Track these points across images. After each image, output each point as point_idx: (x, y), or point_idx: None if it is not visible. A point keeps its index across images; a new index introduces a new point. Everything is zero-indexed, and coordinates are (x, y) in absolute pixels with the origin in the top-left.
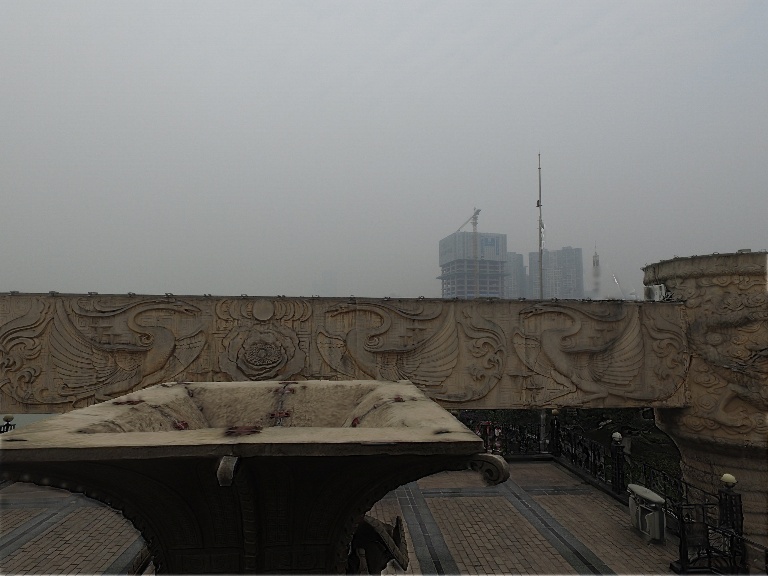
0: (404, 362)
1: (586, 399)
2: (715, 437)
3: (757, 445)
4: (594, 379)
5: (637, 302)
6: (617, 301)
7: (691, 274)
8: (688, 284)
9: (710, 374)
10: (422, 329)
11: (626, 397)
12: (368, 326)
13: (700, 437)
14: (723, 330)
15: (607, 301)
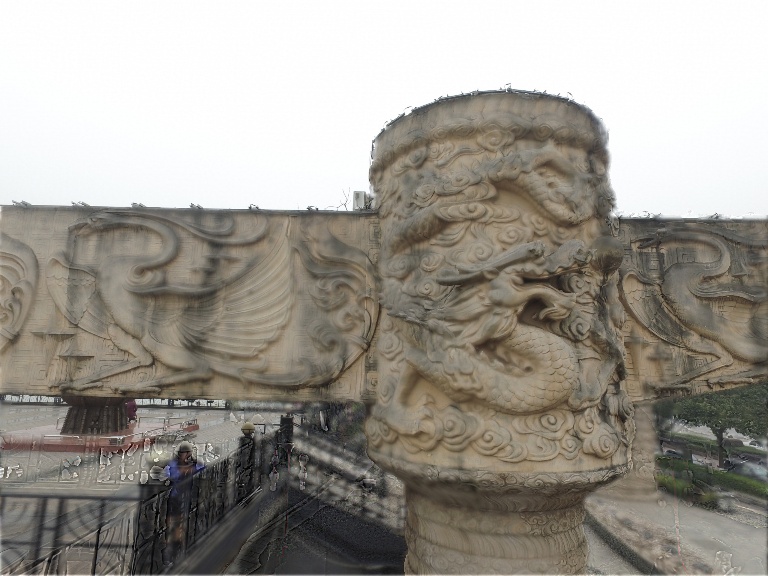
0: None
1: (164, 379)
2: (392, 458)
3: (446, 476)
4: (183, 342)
5: (288, 210)
6: None
7: (382, 158)
8: (384, 178)
9: (393, 334)
10: None
11: (242, 377)
12: None
13: (379, 458)
14: (413, 248)
15: (232, 208)
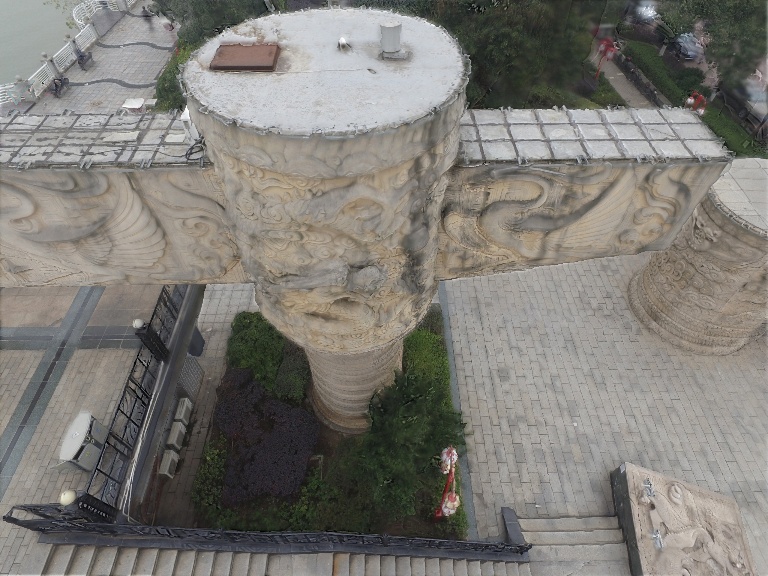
0: None
1: (97, 281)
2: None
3: None
4: (95, 264)
5: (121, 167)
6: (78, 169)
7: None
8: None
9: None
10: None
11: (154, 279)
12: None
13: None
14: None
15: (63, 166)
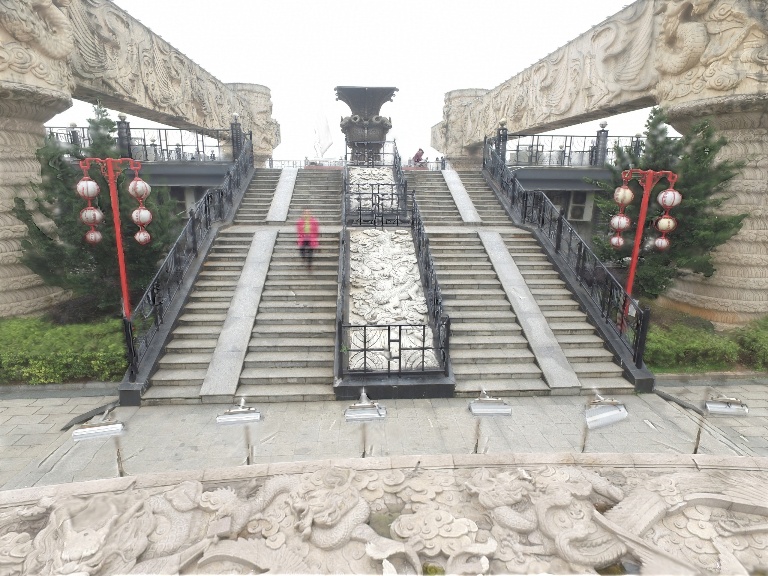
0: (549, 94)
1: (609, 98)
2: None
3: None
4: (615, 80)
5: None
6: None
7: None
8: None
9: None
10: (556, 70)
11: (630, 90)
12: (543, 75)
13: None
14: None
15: None
